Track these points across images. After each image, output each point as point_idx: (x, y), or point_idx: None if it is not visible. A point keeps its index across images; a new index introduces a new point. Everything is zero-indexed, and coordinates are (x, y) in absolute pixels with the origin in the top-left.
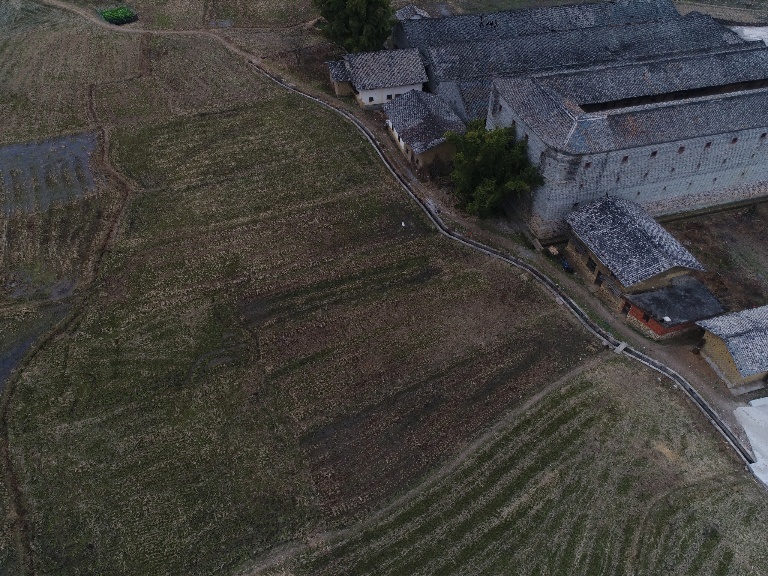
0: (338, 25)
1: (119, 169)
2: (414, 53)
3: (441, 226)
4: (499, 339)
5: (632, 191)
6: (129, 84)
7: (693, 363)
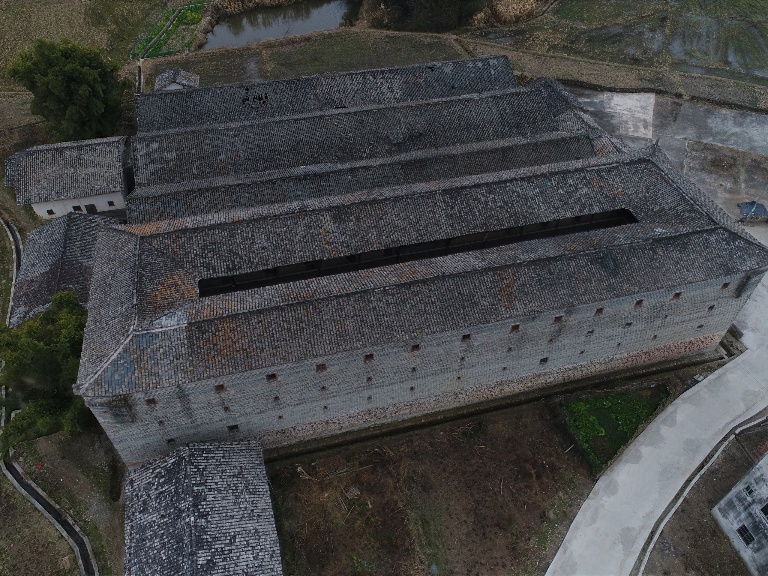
0: (36, 105)
1: None
2: (113, 150)
3: None
4: None
5: (266, 416)
6: None
7: None
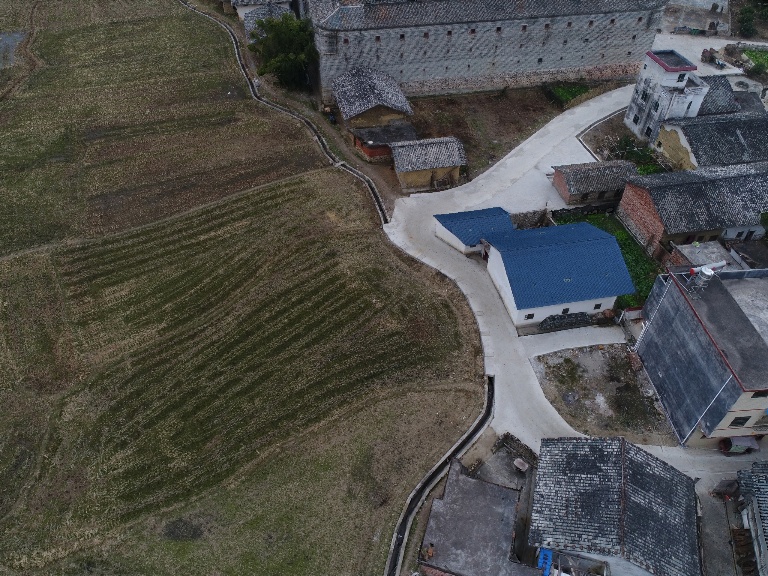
0: None
1: (36, 53)
2: None
3: (256, 95)
4: (257, 157)
5: (395, 69)
6: (67, 2)
7: (387, 175)
